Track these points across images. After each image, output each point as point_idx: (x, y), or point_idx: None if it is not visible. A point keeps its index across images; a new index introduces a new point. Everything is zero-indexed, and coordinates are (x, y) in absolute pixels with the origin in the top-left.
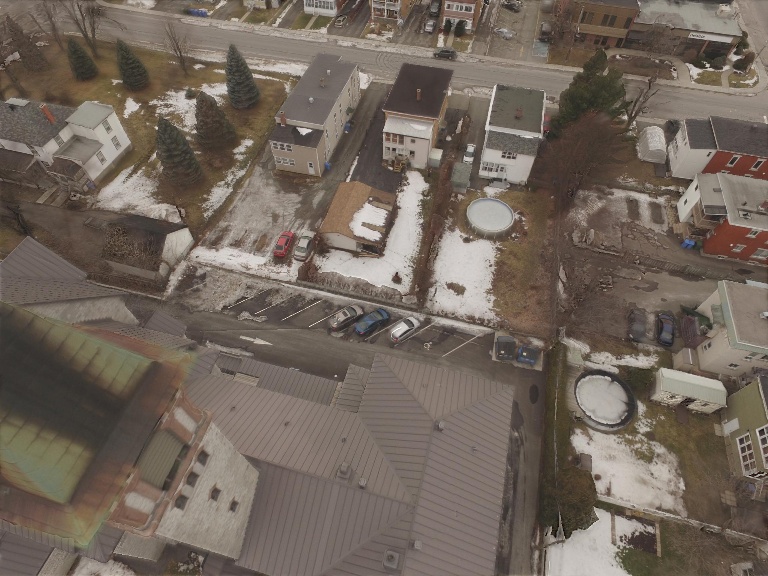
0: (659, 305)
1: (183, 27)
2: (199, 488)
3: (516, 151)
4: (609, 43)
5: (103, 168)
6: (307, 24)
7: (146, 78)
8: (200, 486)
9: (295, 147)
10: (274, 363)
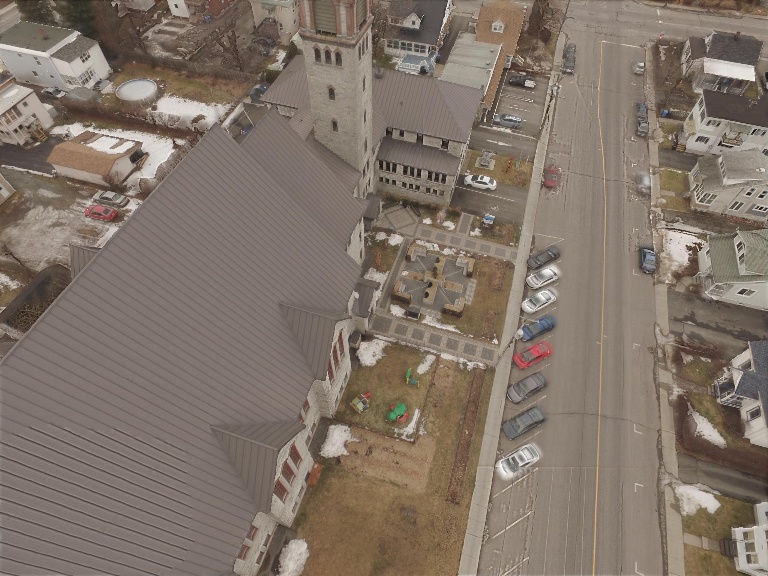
0: (247, 41)
1: None
2: None
3: (85, 49)
4: None
5: None
6: None
7: None
8: None
9: None
10: None
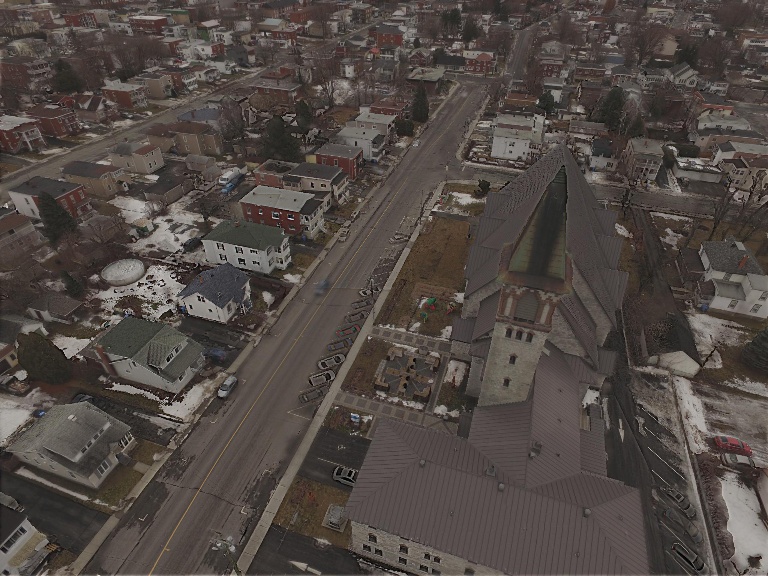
0: None
1: None
2: (515, 343)
3: None
4: None
5: (725, 309)
6: None
7: None
8: (516, 343)
9: None
10: (607, 444)
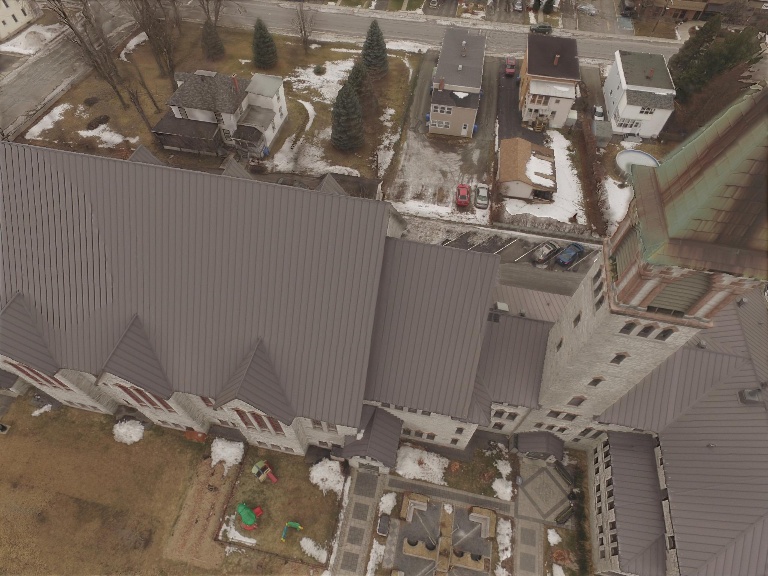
0: None
1: (285, 11)
2: None
3: (655, 106)
4: (687, 16)
5: (273, 136)
6: (402, 6)
7: (276, 56)
8: None
9: (456, 109)
10: None
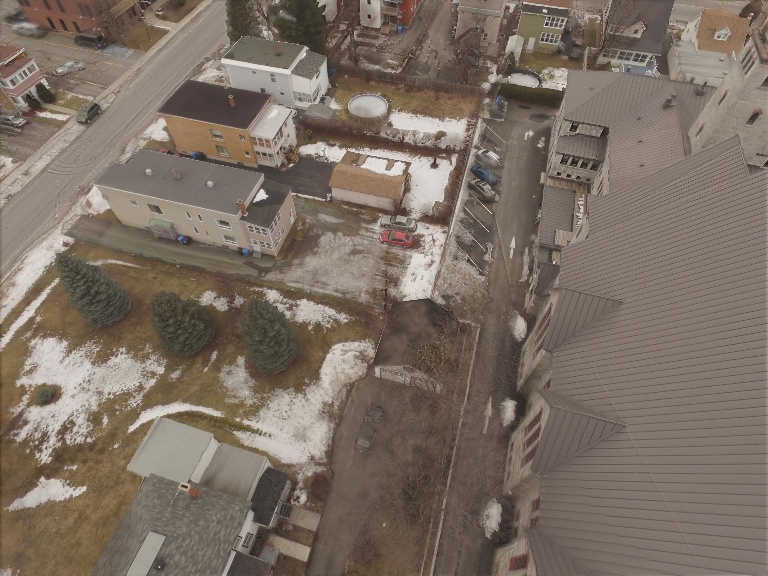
0: (449, 52)
1: None
2: None
3: (320, 65)
4: None
5: None
6: None
7: None
8: None
9: (282, 208)
10: (531, 233)
